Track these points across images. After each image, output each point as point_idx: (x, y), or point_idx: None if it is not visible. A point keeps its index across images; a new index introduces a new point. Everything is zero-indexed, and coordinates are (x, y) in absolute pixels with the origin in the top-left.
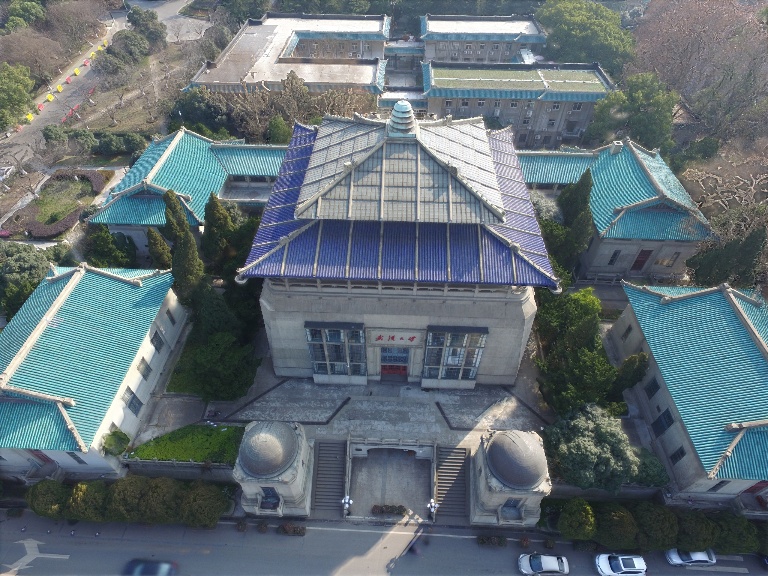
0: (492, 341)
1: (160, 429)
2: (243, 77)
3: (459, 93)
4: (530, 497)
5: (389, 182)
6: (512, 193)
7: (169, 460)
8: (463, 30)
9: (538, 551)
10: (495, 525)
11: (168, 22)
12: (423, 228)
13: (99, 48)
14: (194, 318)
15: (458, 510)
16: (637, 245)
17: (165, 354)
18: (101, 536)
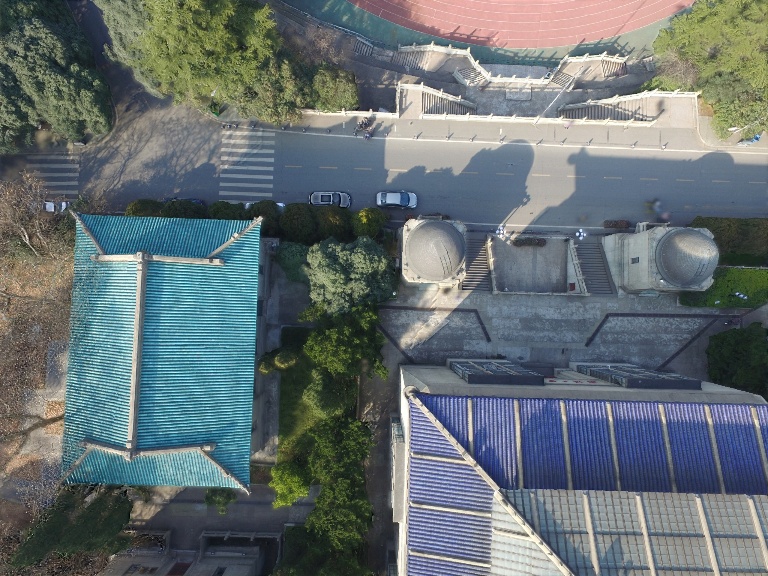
0: None
1: None
2: None
3: None
4: None
5: None
6: None
7: (762, 269)
8: None
9: (397, 213)
10: None
11: None
12: None
13: None
14: None
15: (466, 244)
16: None
17: None
18: None
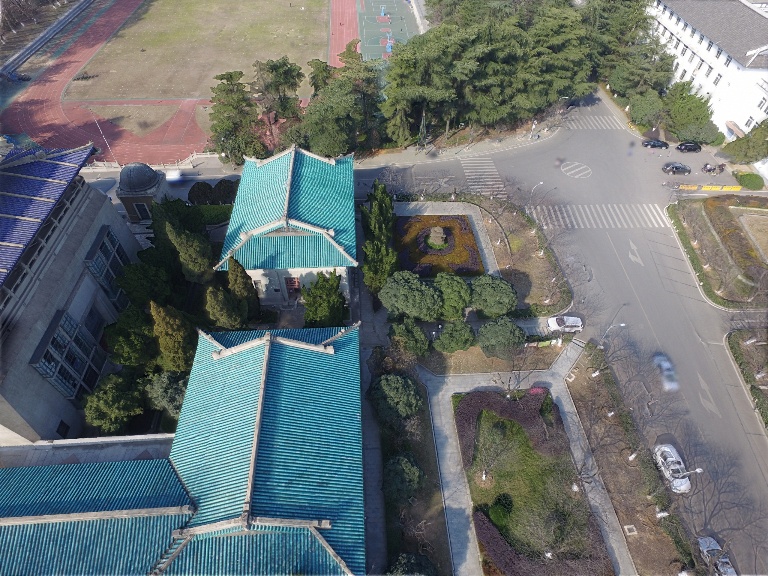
0: None
1: None
2: None
3: None
4: None
5: None
6: None
7: None
8: None
9: None
10: None
11: None
12: None
13: None
14: None
15: None
16: None
17: None
18: None
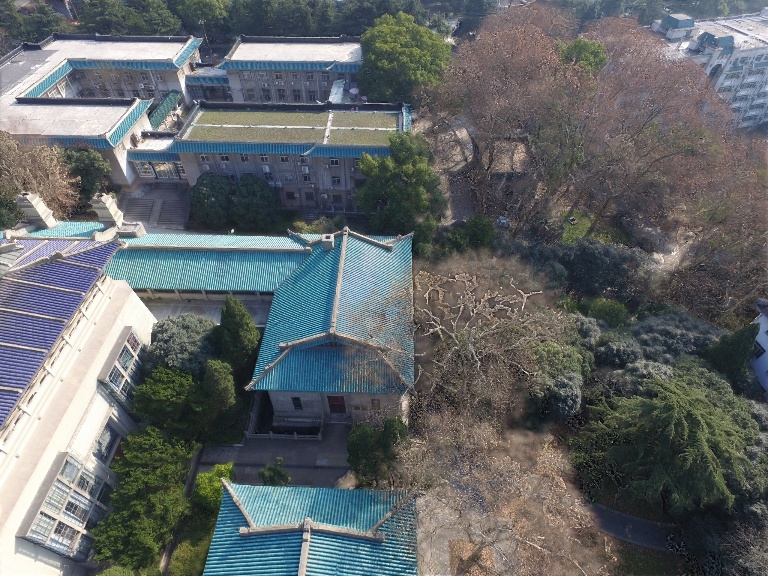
0: None
1: None
2: None
3: (209, 147)
4: None
5: None
6: None
7: None
8: (274, 56)
9: None
10: None
11: None
12: None
13: None
14: None
15: None
16: (315, 392)
17: None
18: None
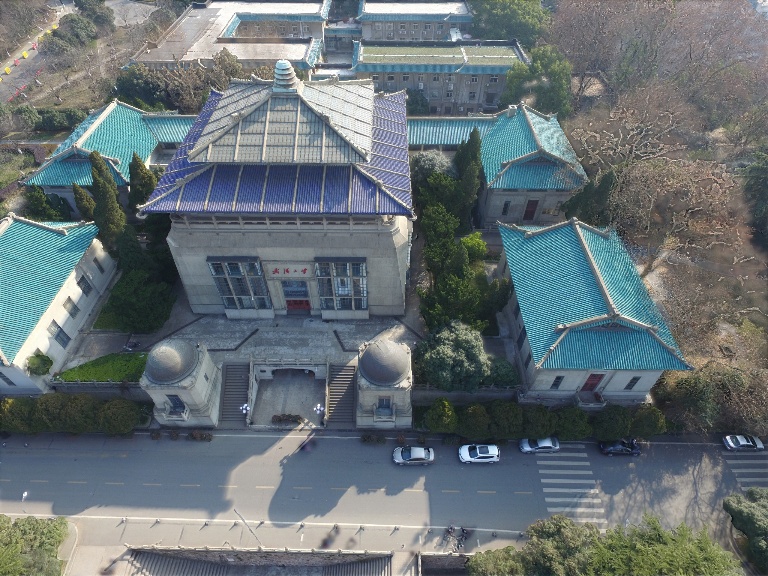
0: (374, 271)
1: (85, 359)
2: (182, 56)
3: (384, 68)
4: (395, 394)
5: (272, 130)
6: (391, 143)
7: (90, 381)
8: (397, 11)
9: None
10: (377, 428)
11: (115, 6)
12: (303, 170)
13: (48, 32)
14: (120, 266)
15: (347, 417)
16: (523, 195)
17: (94, 298)
18: (30, 447)
